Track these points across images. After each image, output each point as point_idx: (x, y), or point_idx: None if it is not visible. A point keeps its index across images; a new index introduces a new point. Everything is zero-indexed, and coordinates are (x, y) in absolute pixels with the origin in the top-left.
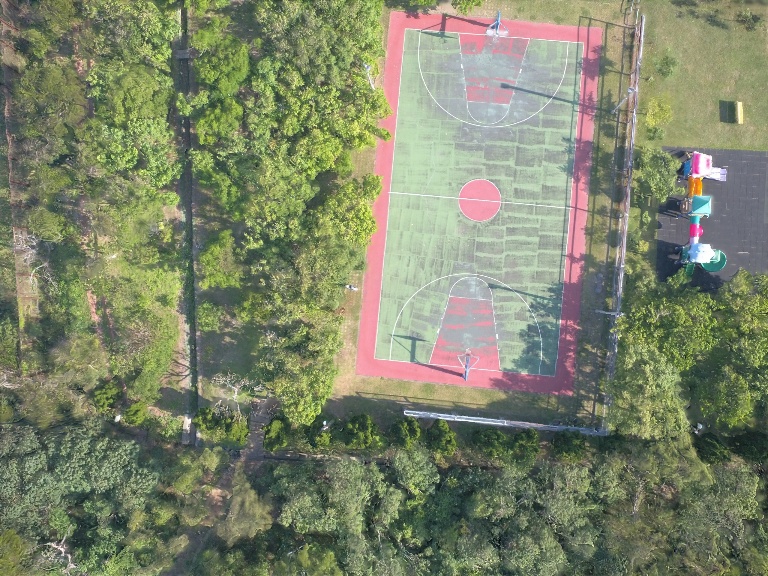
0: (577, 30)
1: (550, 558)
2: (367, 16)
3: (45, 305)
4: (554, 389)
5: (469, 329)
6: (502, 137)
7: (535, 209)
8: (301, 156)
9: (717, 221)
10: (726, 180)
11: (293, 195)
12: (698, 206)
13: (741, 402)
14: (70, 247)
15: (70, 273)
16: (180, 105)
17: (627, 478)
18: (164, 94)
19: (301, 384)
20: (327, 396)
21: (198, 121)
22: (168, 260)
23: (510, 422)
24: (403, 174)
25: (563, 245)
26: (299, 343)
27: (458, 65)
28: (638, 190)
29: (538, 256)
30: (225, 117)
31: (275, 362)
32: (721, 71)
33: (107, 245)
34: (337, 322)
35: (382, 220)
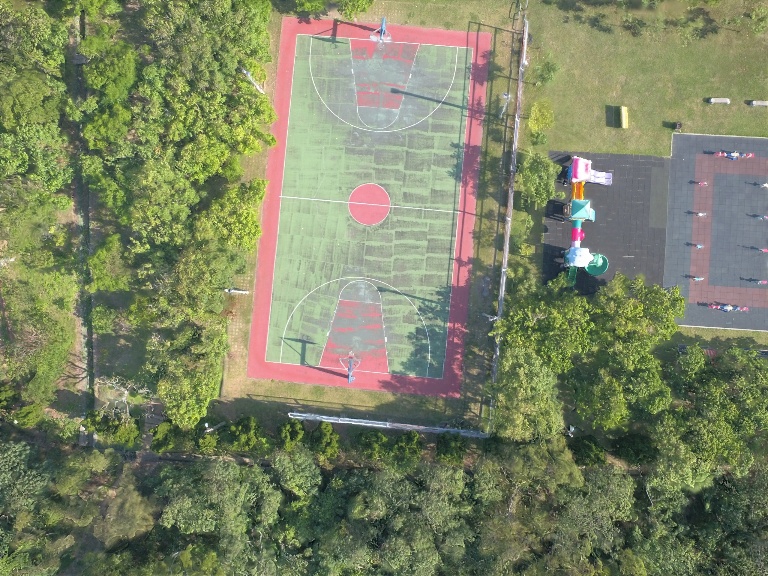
0: (466, 35)
1: (422, 559)
2: (250, 22)
3: None
4: (442, 391)
5: (358, 332)
6: (392, 142)
7: (424, 213)
8: (186, 161)
9: (603, 225)
10: (611, 184)
11: (176, 200)
12: (576, 210)
13: (612, 405)
14: None
15: None
16: (70, 110)
17: (504, 480)
18: (55, 99)
19: (182, 387)
20: (217, 398)
21: (87, 126)
22: (64, 263)
23: (392, 424)
24: (294, 178)
25: (451, 249)
26: (187, 346)
27: (349, 70)
28: (525, 194)
29: (426, 260)
30: (112, 122)
31: (160, 365)
32: (607, 76)
33: (6, 249)
34: (220, 325)
35: (273, 224)
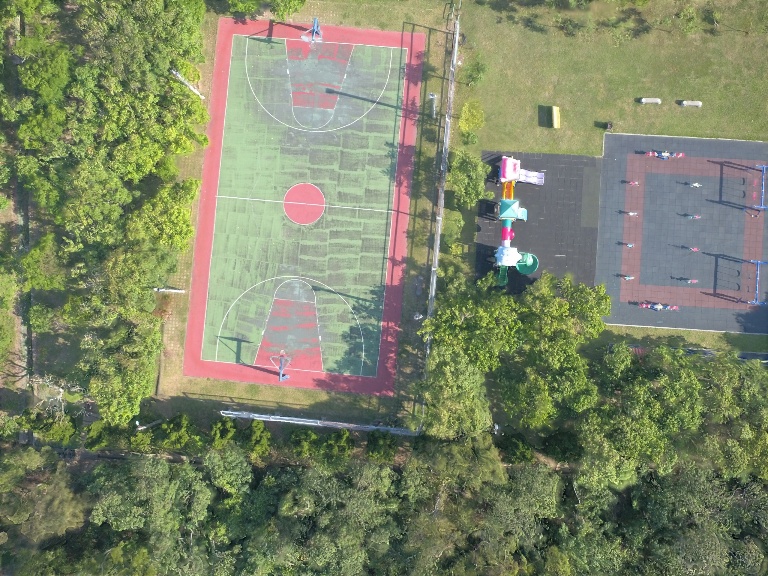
0: (401, 36)
1: (347, 556)
2: (182, 23)
3: None
4: (375, 390)
5: (293, 331)
6: (326, 141)
7: (358, 212)
8: (119, 161)
9: (535, 224)
10: (544, 184)
11: (107, 199)
12: (503, 210)
13: (537, 403)
14: None
15: None
16: (5, 111)
17: None
18: None
19: (112, 385)
20: None
21: None
22: (4, 263)
23: (323, 422)
24: (230, 178)
25: (385, 248)
26: (121, 345)
27: (284, 70)
28: (458, 194)
29: (361, 259)
30: (46, 122)
31: (93, 363)
32: (540, 76)
33: None
34: (152, 324)
35: (209, 223)
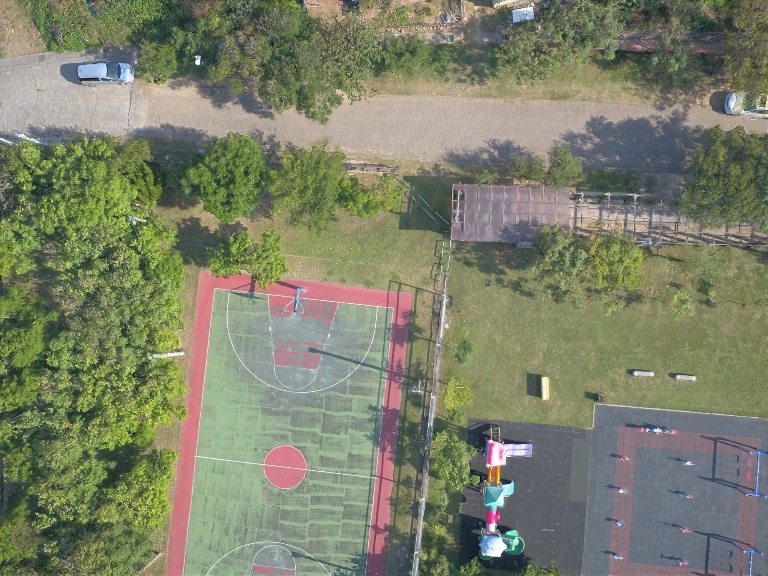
0: (387, 295)
1: None
2: (159, 297)
3: None
4: None
5: None
6: (309, 403)
7: (340, 478)
8: (94, 435)
9: (522, 496)
10: (531, 456)
11: (81, 480)
12: (488, 501)
13: None
14: None
15: None
16: None
17: None
18: None
19: None
20: None
21: None
22: None
23: None
24: (209, 438)
25: (367, 515)
26: None
27: (266, 328)
28: None
29: (342, 526)
30: (19, 392)
31: None
32: (529, 343)
33: None
34: None
35: (187, 484)
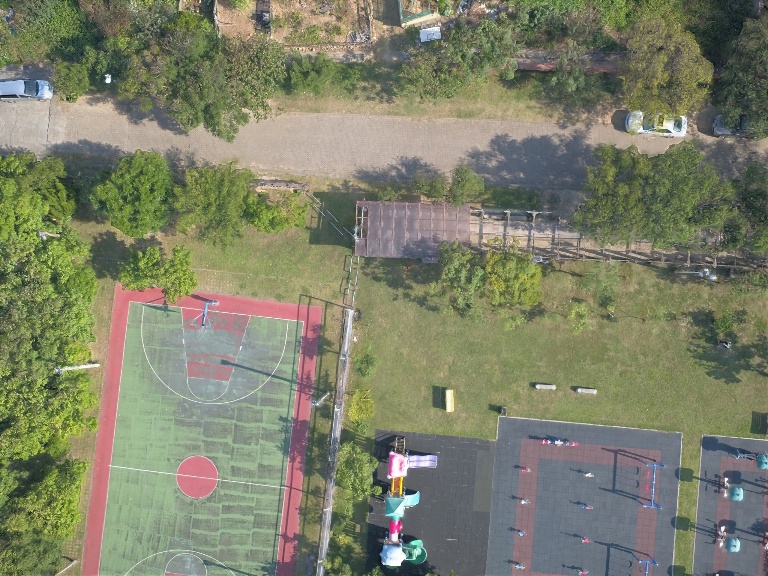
0: (297, 308)
1: None
2: (69, 311)
3: None
4: None
5: None
6: (221, 414)
7: (251, 488)
8: (5, 446)
9: (427, 507)
10: (436, 467)
11: None
12: (388, 511)
13: None
14: None
15: None
16: None
17: None
18: None
19: None
20: None
21: None
22: None
23: None
24: (123, 448)
25: (277, 524)
26: None
27: (180, 340)
28: None
29: (252, 535)
30: None
31: None
32: (435, 356)
33: None
34: None
35: (102, 493)
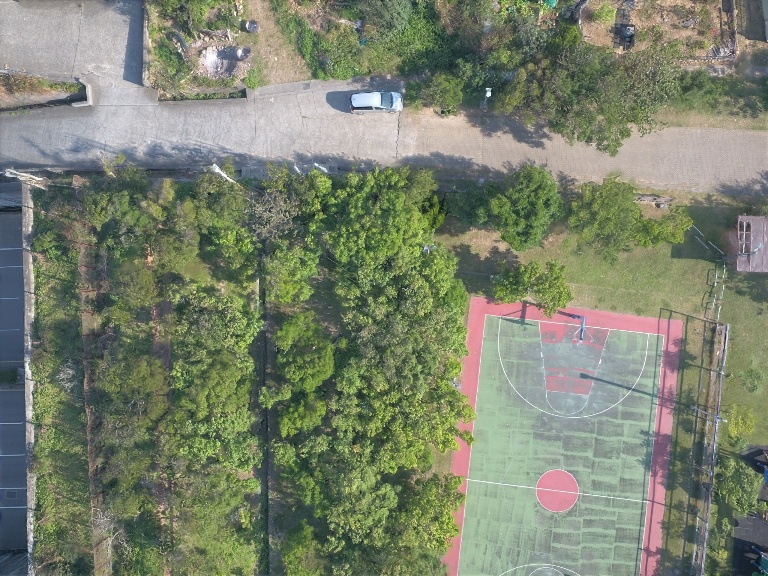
0: (657, 322)
1: None
2: (454, 325)
3: (119, 567)
4: None
5: None
6: (581, 428)
7: (612, 502)
8: (385, 460)
9: None
10: None
11: (378, 505)
12: None
13: None
14: (148, 523)
15: (145, 541)
16: (263, 399)
17: None
18: (246, 384)
19: None
20: None
21: (281, 416)
22: None
23: None
24: (481, 462)
25: (639, 539)
26: None
27: (538, 353)
28: (716, 486)
29: (614, 549)
30: (309, 417)
31: None
32: None
33: None
34: None
35: (459, 507)
